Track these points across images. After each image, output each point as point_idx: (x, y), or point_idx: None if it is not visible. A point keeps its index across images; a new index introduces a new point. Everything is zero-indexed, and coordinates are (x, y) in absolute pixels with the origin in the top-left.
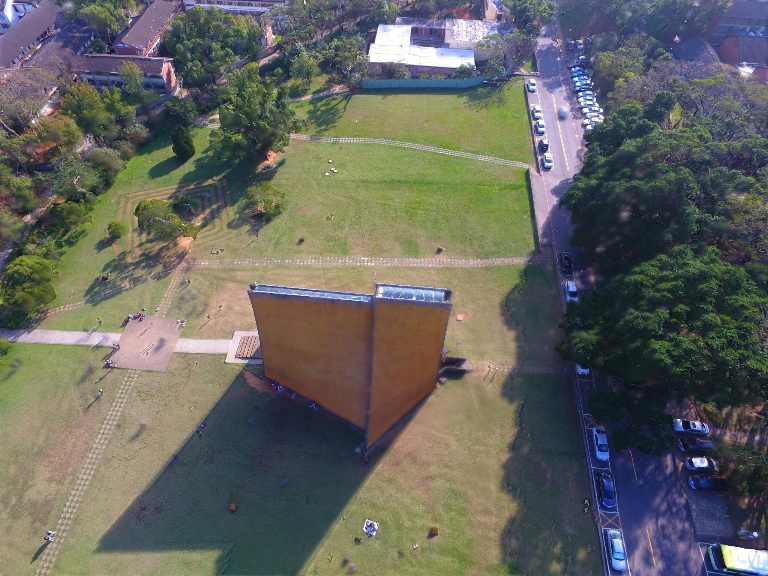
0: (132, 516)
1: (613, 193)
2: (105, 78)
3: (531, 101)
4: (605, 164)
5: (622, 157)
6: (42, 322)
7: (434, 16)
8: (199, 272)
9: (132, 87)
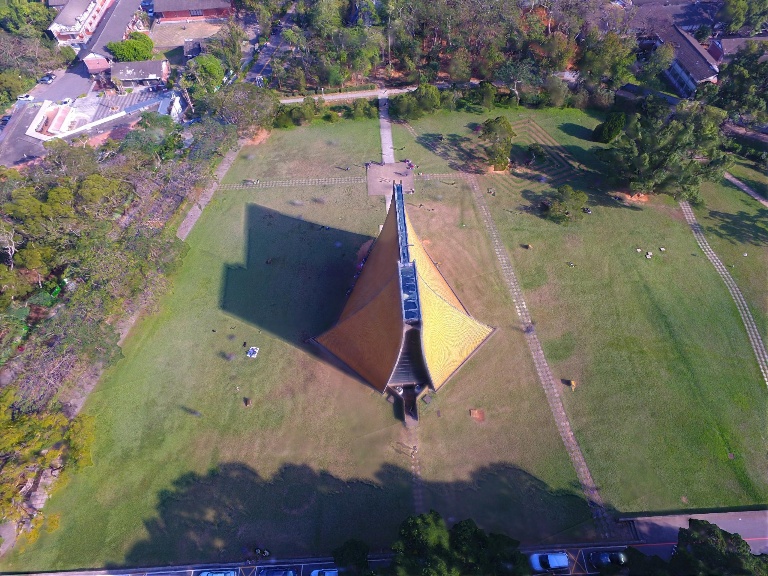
0: (266, 212)
1: None
2: None
3: None
4: None
5: None
6: (397, 124)
7: None
8: (465, 187)
9: (648, 65)
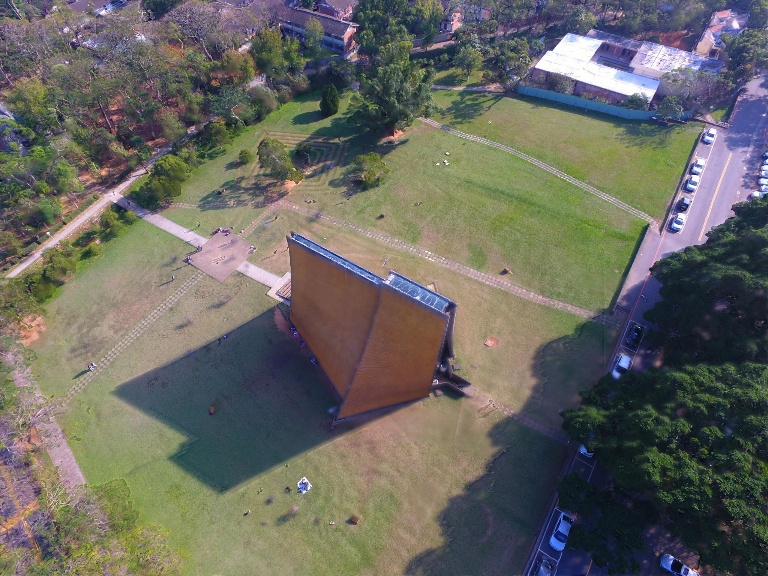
0: (146, 380)
1: (708, 276)
2: (301, 30)
3: (698, 153)
4: (729, 243)
5: (751, 241)
6: (164, 210)
7: (636, 36)
8: (287, 213)
9: (310, 42)
